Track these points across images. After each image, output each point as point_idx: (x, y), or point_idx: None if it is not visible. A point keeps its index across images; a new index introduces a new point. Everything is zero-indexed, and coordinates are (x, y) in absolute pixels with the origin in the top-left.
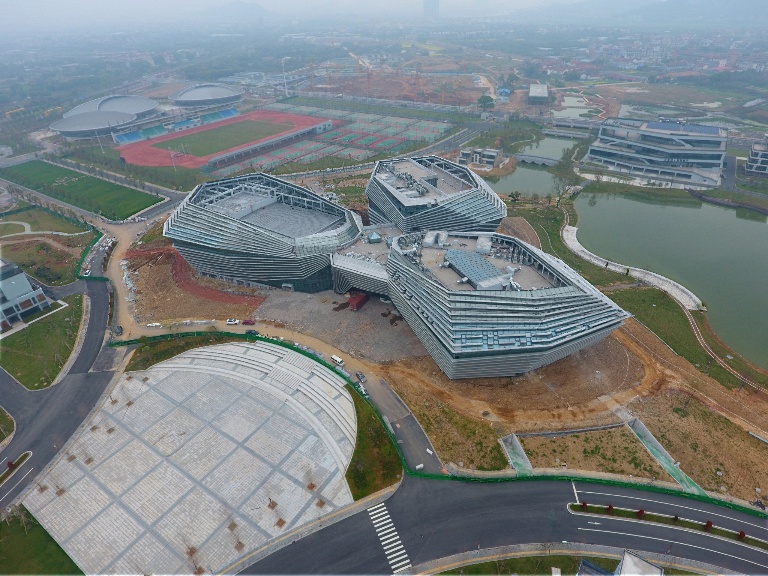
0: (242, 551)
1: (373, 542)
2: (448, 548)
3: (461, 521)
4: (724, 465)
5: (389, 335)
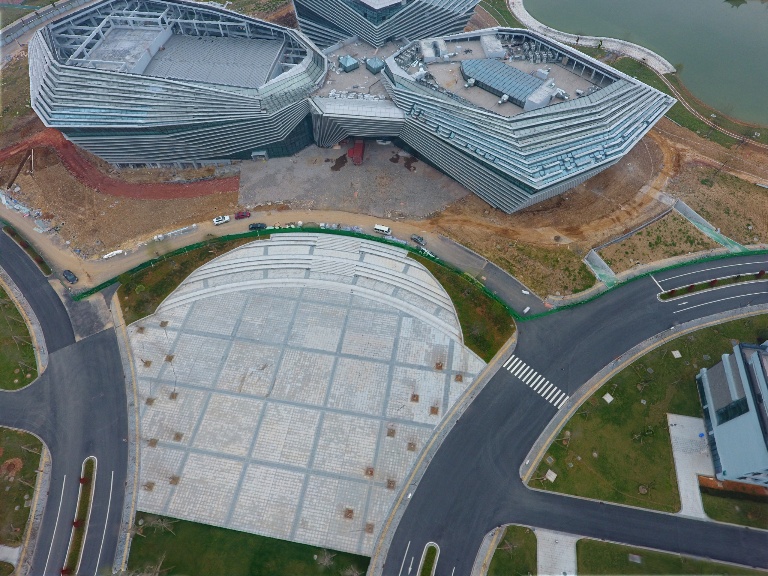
0: (417, 450)
1: (526, 392)
2: (589, 370)
3: (586, 344)
4: (752, 219)
5: (415, 183)
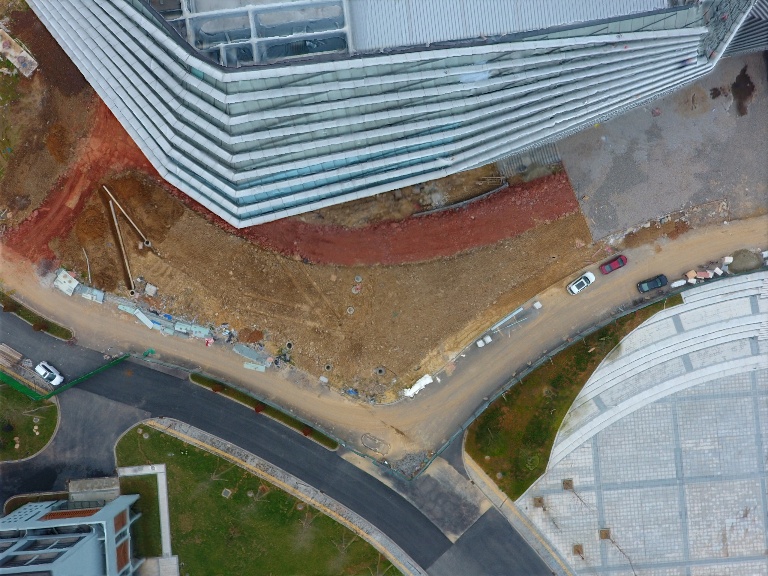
0: None
1: None
2: None
3: None
4: None
5: None
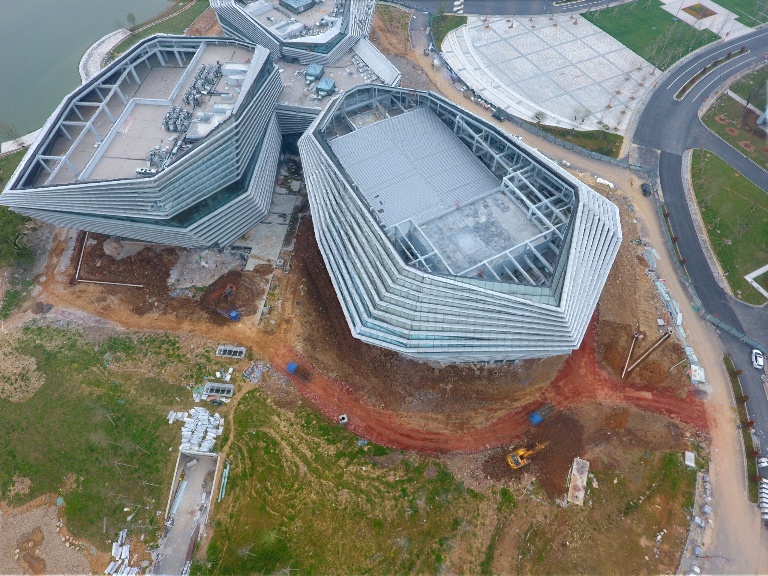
0: None
1: (467, 4)
2: None
3: None
4: None
5: None
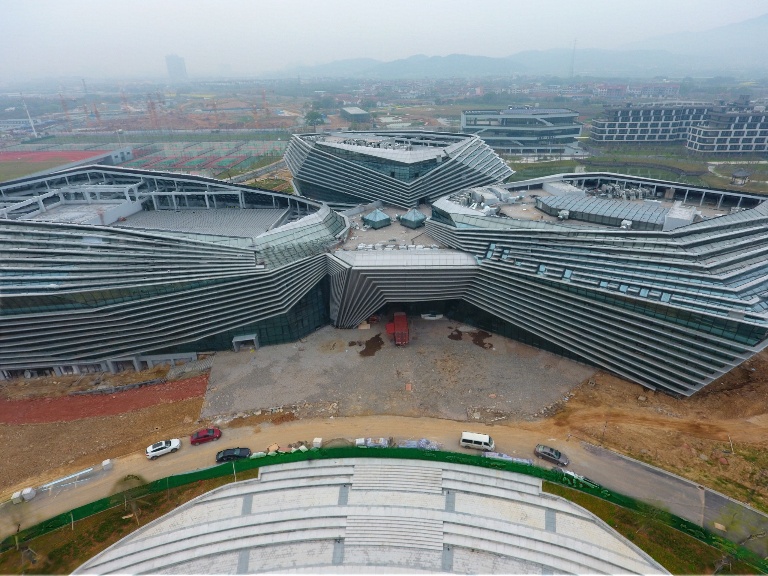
0: None
1: None
2: None
3: None
4: None
5: (500, 364)
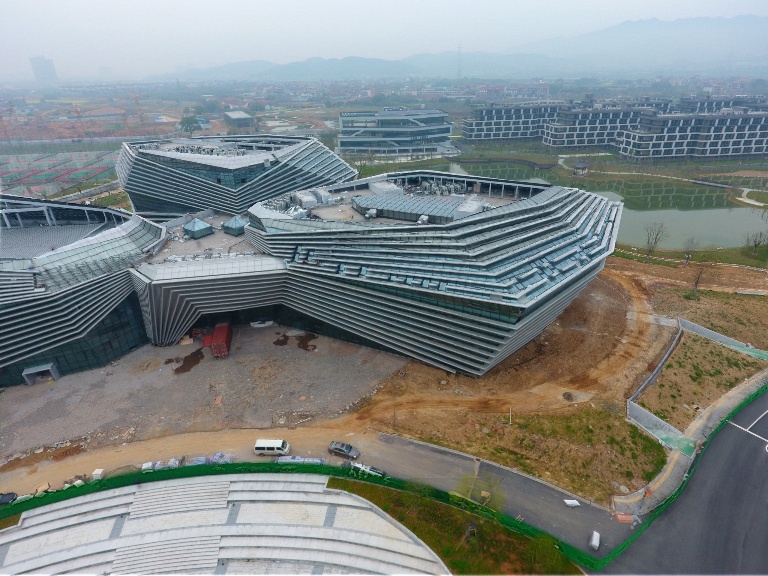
0: None
1: None
2: None
3: None
4: None
5: (319, 365)
